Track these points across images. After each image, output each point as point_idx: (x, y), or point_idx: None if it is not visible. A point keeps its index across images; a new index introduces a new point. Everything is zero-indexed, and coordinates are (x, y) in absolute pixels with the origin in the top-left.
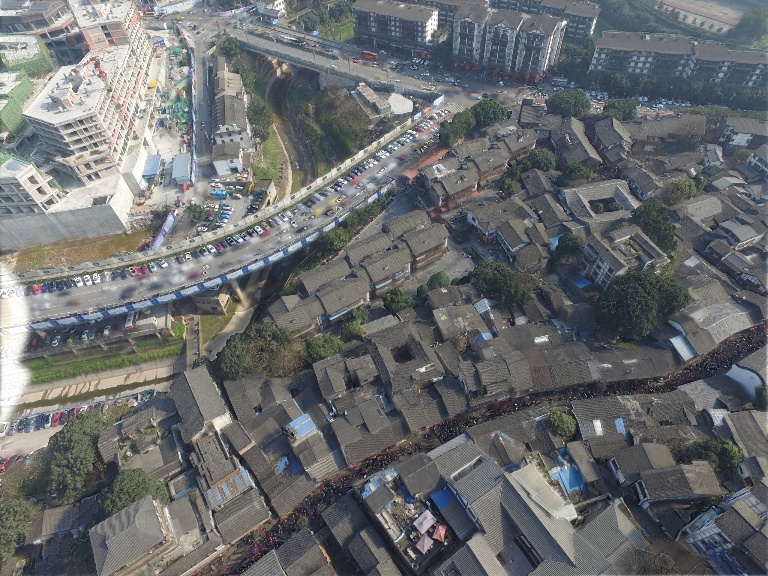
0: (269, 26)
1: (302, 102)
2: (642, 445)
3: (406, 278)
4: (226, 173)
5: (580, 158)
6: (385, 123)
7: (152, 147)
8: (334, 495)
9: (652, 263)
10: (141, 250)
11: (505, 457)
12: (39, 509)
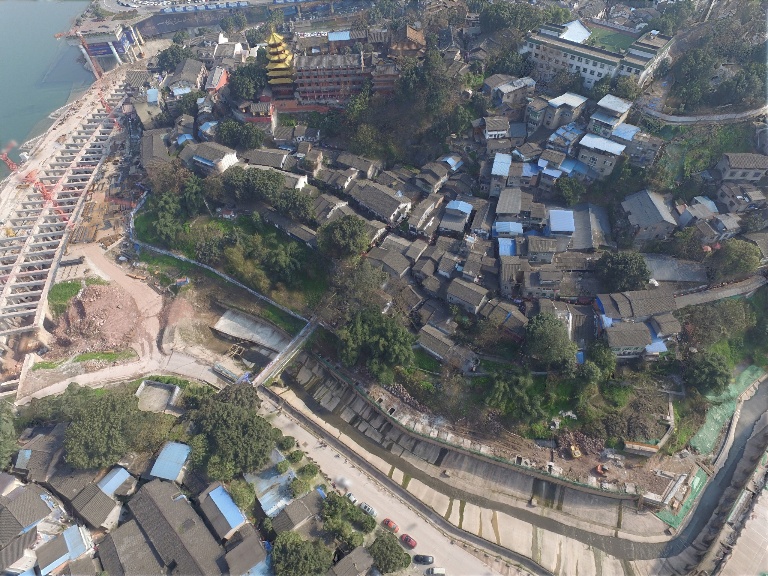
0: None
1: None
2: None
3: None
4: None
5: None
6: None
7: None
8: None
9: None
10: None
11: None
12: (382, 15)
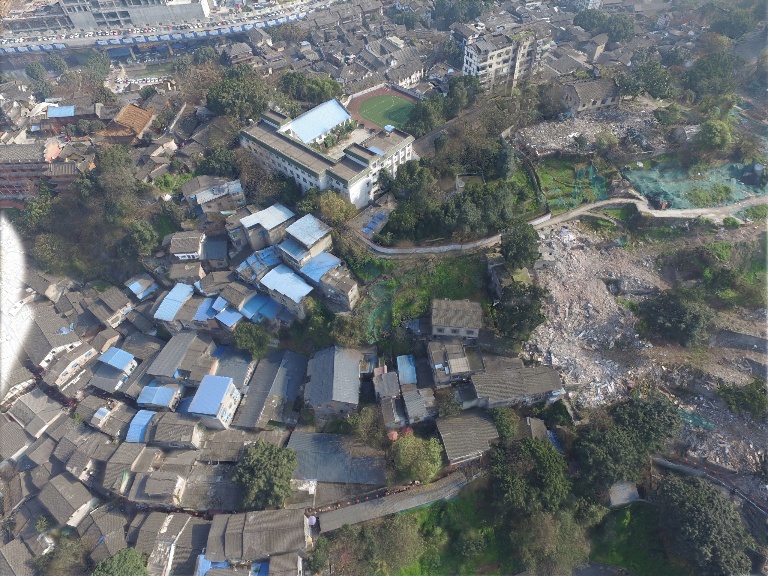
0: None
1: None
2: None
3: None
4: (263, 1)
5: None
6: None
7: None
8: None
9: None
10: None
11: None
12: (195, 66)
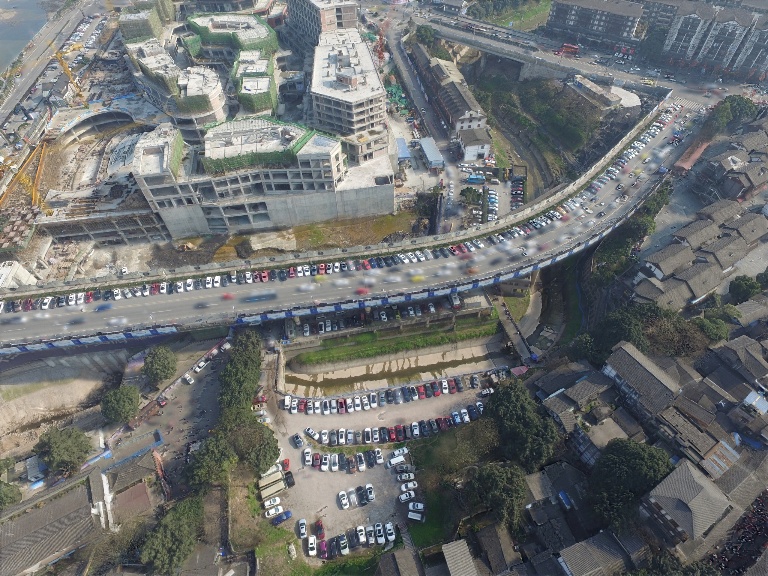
0: (450, 16)
1: (503, 92)
2: None
3: None
4: (472, 159)
5: None
6: (616, 115)
7: None
8: None
9: None
10: (416, 231)
11: None
12: (524, 475)
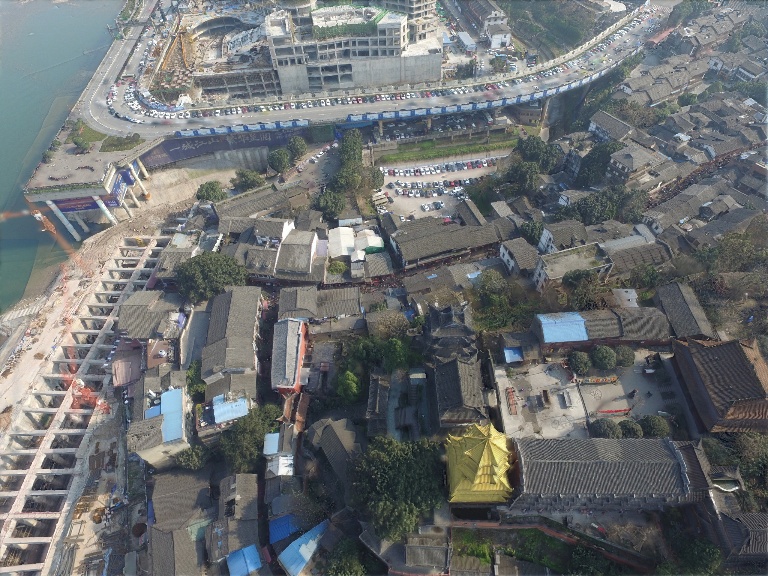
0: None
1: (519, 10)
2: None
3: None
4: (497, 47)
5: None
6: (607, 17)
7: None
8: None
9: None
10: None
11: None
12: None
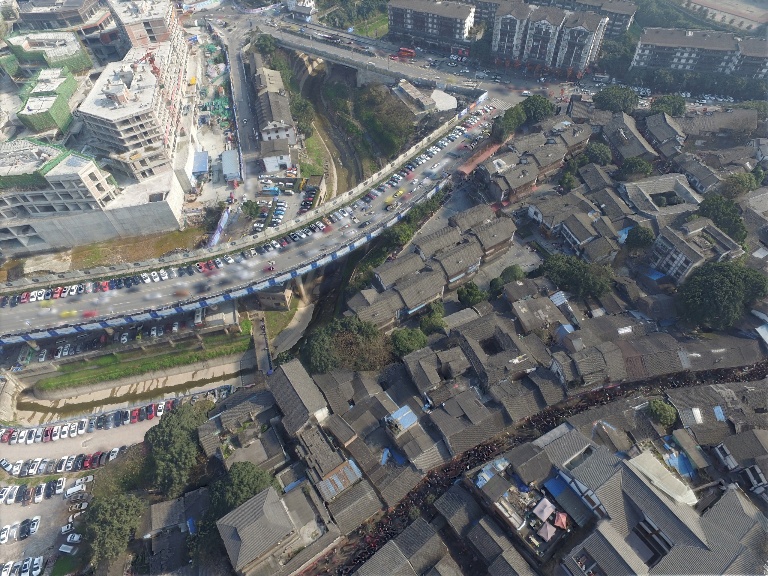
0: (301, 23)
1: (340, 99)
2: (753, 431)
3: (475, 272)
4: (275, 170)
5: (637, 152)
6: (430, 119)
7: (197, 144)
8: (439, 486)
9: (727, 254)
10: (197, 247)
11: (611, 446)
12: (147, 504)
